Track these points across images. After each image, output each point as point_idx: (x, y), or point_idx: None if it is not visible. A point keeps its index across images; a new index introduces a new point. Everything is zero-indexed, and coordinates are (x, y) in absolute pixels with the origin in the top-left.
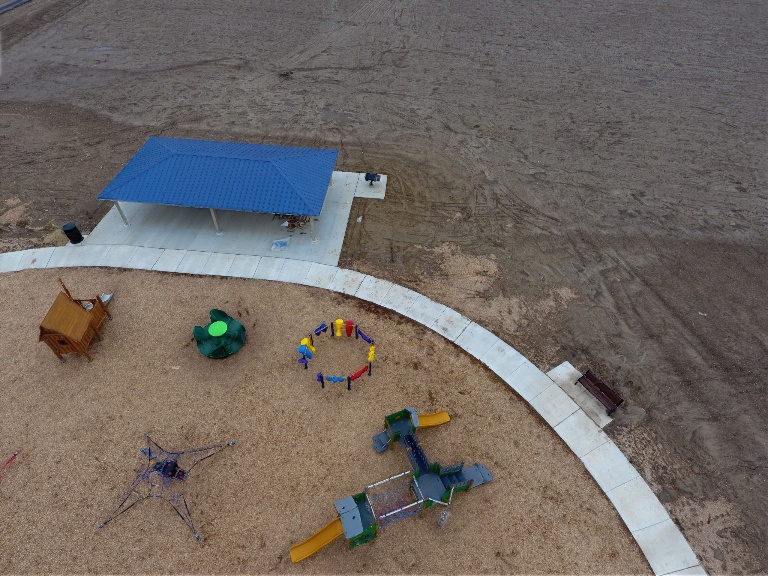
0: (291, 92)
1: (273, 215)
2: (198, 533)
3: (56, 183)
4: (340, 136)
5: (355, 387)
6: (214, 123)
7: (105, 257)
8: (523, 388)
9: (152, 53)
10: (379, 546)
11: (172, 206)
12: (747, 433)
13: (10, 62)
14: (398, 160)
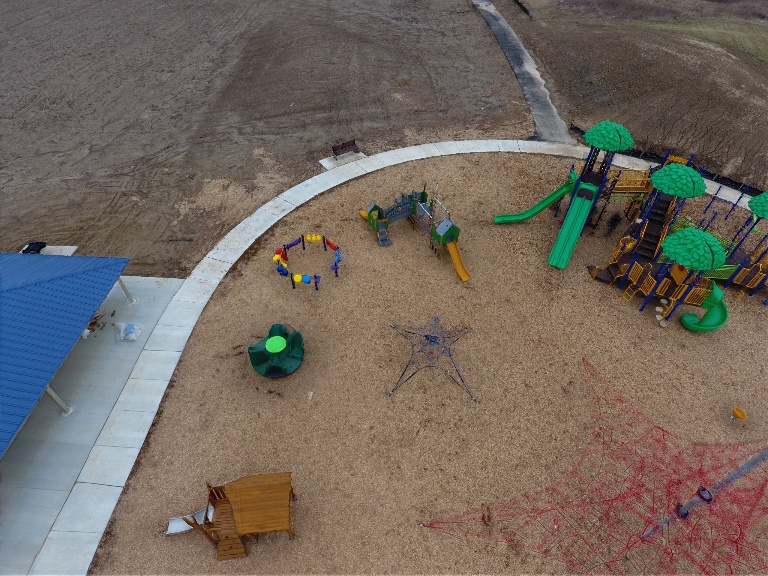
0: None
1: None
2: None
3: None
4: None
5: None
6: None
7: None
8: (339, 180)
9: None
10: None
11: None
12: (370, 113)
13: None
14: None
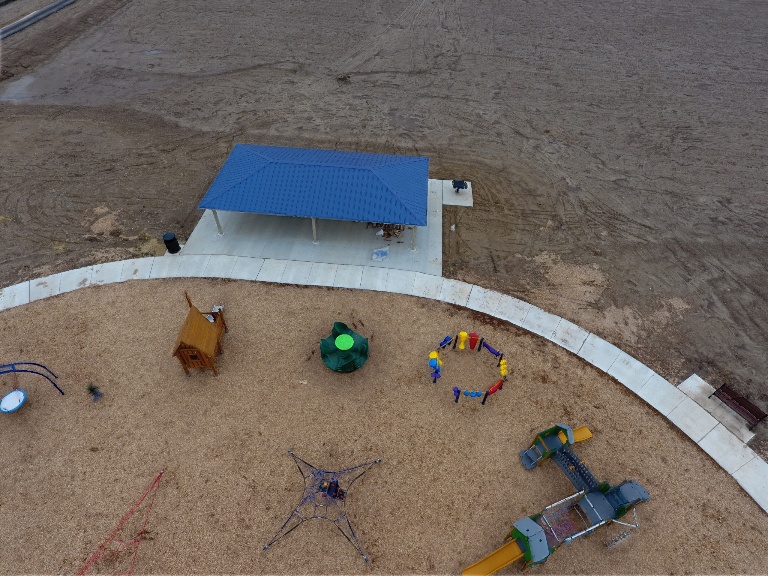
0: (353, 96)
1: (366, 223)
2: (365, 554)
3: (141, 191)
4: (412, 142)
5: (488, 401)
6: (283, 128)
7: (206, 267)
8: (657, 402)
9: (204, 57)
10: (549, 567)
11: (262, 214)
12: None
13: (64, 66)
14: (477, 166)
